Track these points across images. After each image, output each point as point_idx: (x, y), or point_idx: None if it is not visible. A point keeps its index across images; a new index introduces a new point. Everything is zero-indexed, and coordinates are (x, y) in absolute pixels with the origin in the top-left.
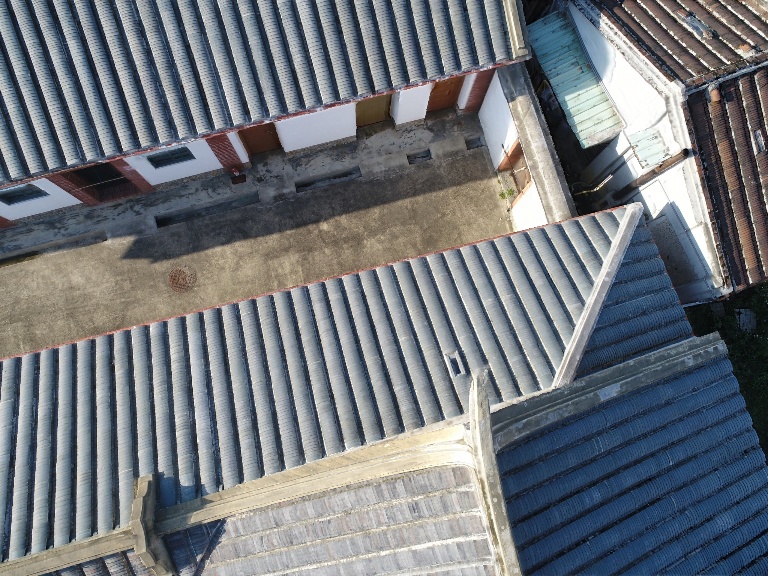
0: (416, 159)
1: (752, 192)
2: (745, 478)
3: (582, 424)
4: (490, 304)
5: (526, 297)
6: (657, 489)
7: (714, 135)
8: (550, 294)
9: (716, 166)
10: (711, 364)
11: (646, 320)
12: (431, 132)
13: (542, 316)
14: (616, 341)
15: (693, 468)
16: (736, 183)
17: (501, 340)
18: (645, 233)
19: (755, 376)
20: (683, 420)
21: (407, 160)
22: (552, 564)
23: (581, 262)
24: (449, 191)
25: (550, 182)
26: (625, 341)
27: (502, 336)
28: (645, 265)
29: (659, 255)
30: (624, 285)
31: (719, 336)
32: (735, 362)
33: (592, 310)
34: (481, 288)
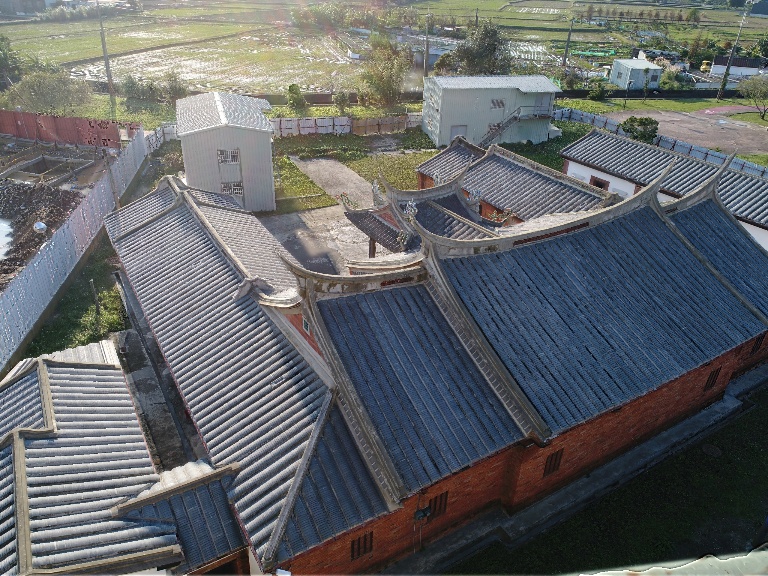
0: None
1: None
2: None
3: None
4: None
5: None
6: None
7: None
8: None
9: None
10: None
11: None
12: None
13: None
14: None
15: None
16: None
17: None
18: None
19: None
20: None
21: None
22: (695, 220)
23: None
24: None
25: None
26: None
27: None
28: None
29: None
30: None
31: None
32: None
33: None
34: None
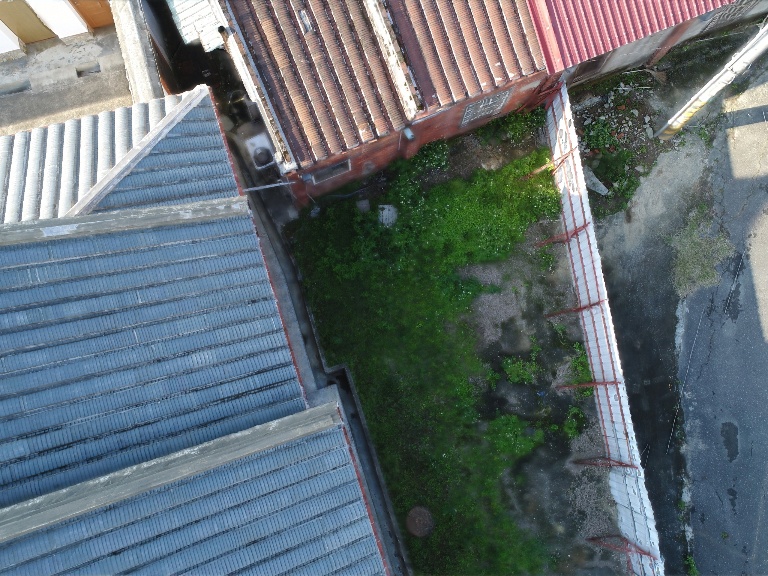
0: (90, 74)
1: (304, 70)
2: (243, 323)
3: (12, 254)
4: (30, 174)
5: (65, 167)
6: (114, 322)
7: (256, 15)
8: (86, 163)
9: (262, 45)
10: (224, 221)
11: (182, 187)
12: (100, 47)
13: (69, 181)
14: (141, 204)
15: (171, 308)
16: (285, 61)
17: (24, 203)
18: (206, 112)
19: (387, 265)
20: (168, 266)
21: (76, 73)
22: None
23: (131, 137)
24: (115, 102)
25: (137, 72)
26: (151, 204)
27: (26, 199)
28: (197, 140)
29: (223, 133)
30: (163, 155)
31: (245, 199)
32: (371, 253)
33: (110, 173)
34: (30, 161)
